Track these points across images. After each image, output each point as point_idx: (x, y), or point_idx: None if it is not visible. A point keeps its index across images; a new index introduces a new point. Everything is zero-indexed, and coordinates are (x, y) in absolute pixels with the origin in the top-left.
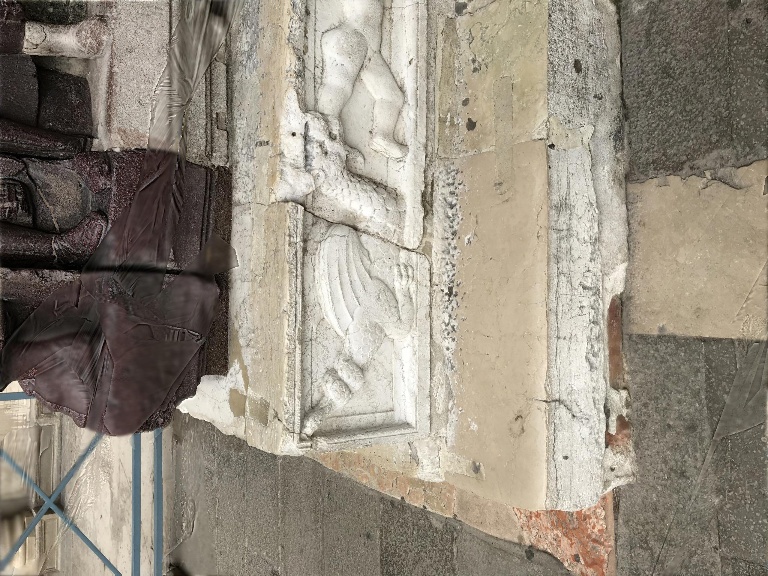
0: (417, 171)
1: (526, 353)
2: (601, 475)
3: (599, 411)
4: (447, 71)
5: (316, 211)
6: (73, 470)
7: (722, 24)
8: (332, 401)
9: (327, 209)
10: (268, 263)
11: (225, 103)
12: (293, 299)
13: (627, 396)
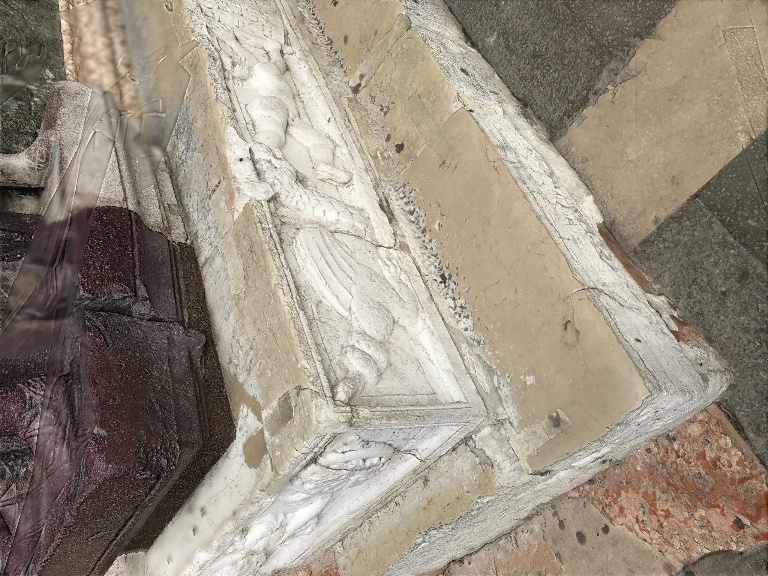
0: (367, 187)
1: (539, 262)
2: (690, 365)
3: (646, 305)
4: (363, 127)
5: (282, 218)
6: (53, 334)
7: (555, 1)
8: (359, 372)
9: (292, 218)
10: (247, 266)
11: (174, 198)
12: (281, 272)
13: (667, 300)
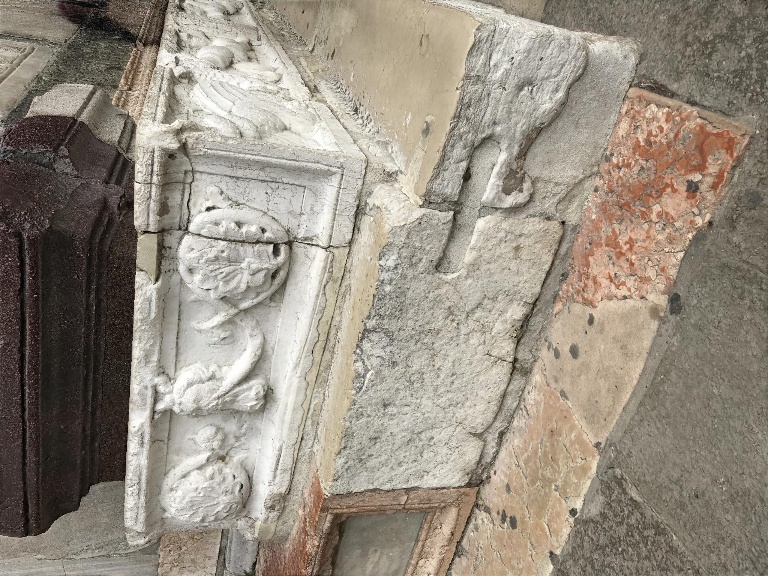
0: (293, 77)
1: (402, 18)
2: None
3: None
4: None
5: None
6: None
7: None
8: None
9: None
10: None
11: None
12: None
13: None
